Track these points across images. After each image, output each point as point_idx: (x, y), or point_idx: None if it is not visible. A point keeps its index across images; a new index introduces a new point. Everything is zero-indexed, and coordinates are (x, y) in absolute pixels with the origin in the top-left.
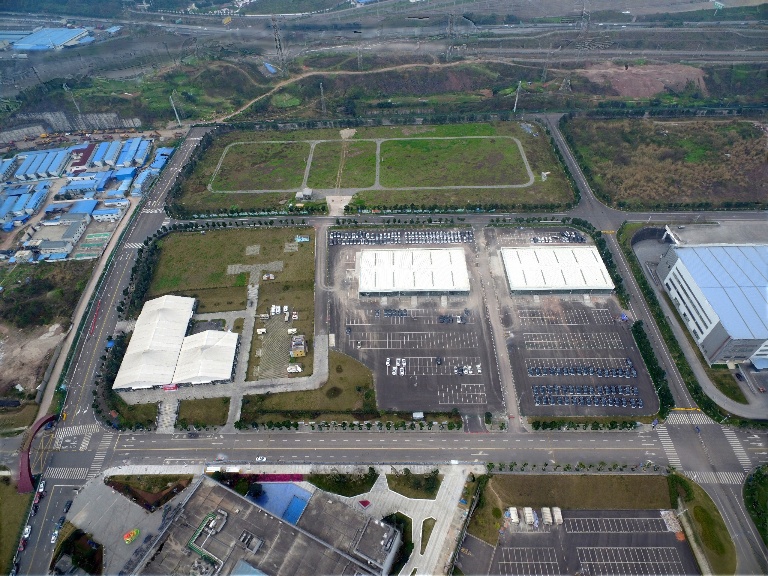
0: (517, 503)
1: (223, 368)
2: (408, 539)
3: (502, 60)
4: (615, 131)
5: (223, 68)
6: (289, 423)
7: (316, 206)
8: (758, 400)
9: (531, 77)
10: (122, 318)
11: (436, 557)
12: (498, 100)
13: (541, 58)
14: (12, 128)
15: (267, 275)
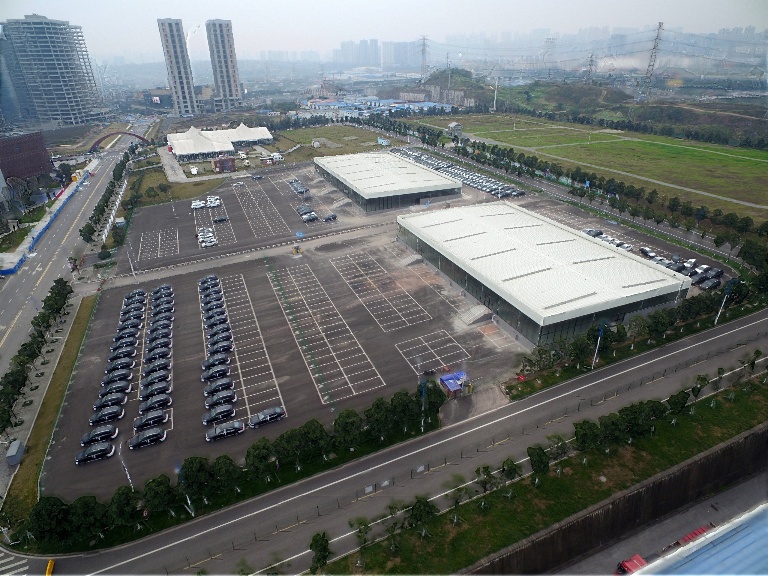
0: None
1: (187, 149)
2: None
3: None
4: None
5: None
6: None
7: None
8: None
9: None
10: None
11: None
12: None
13: None
14: (411, 92)
15: None
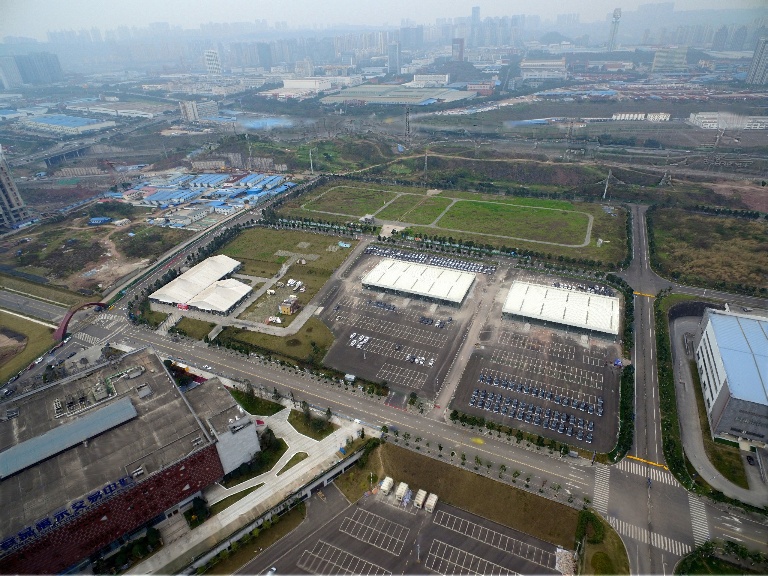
0: (398, 478)
1: (224, 303)
2: (274, 459)
3: (618, 165)
4: (711, 225)
5: (363, 143)
6: (242, 348)
7: (370, 227)
8: (766, 490)
9: (647, 183)
10: (188, 265)
11: (288, 482)
12: (589, 186)
13: (663, 168)
14: (206, 160)
15: (300, 259)
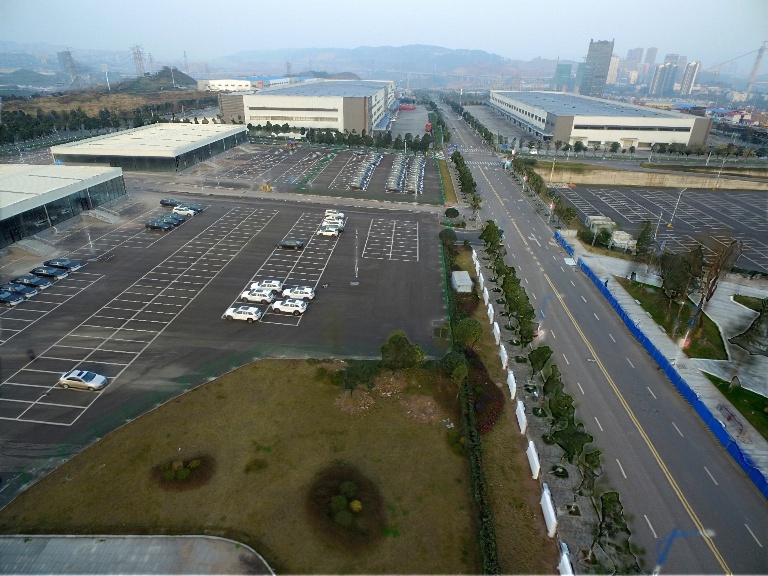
0: None
1: None
2: None
3: None
4: None
5: None
6: None
7: None
8: None
9: None
10: None
11: None
12: None
13: None
14: None
15: None
